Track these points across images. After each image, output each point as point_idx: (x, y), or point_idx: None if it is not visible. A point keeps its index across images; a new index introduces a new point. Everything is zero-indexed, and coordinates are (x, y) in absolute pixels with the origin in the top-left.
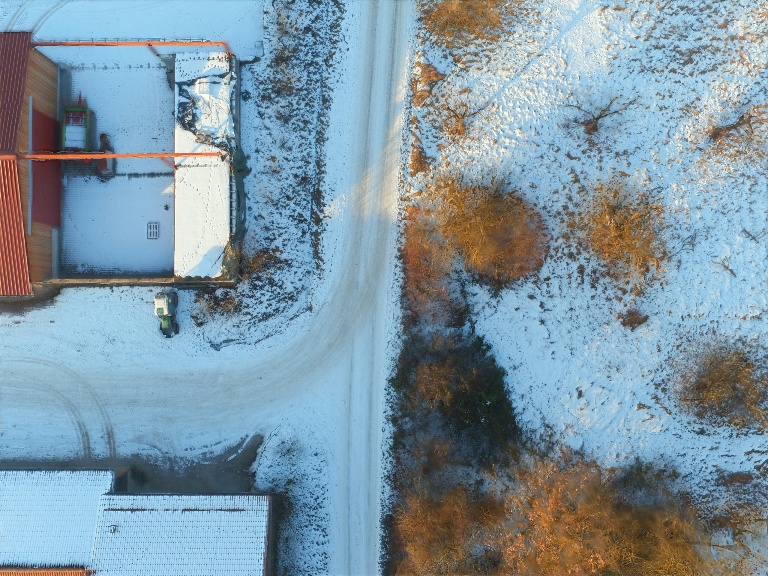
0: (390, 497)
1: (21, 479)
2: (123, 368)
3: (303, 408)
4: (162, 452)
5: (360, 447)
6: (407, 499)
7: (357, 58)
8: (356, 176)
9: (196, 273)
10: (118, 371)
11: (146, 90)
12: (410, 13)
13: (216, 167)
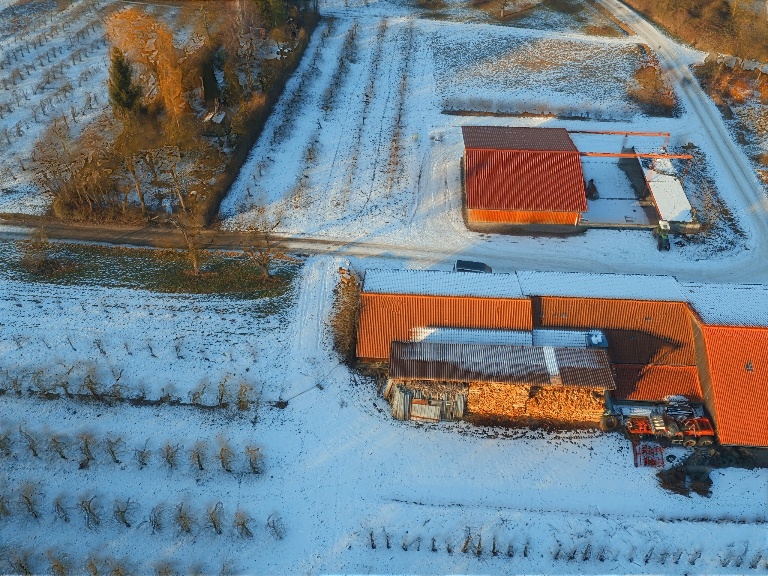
0: None
1: (613, 276)
2: (637, 264)
3: None
4: None
5: None
6: None
7: (721, 168)
8: (745, 205)
9: (676, 220)
10: (634, 265)
11: (607, 170)
12: (742, 157)
13: (672, 182)
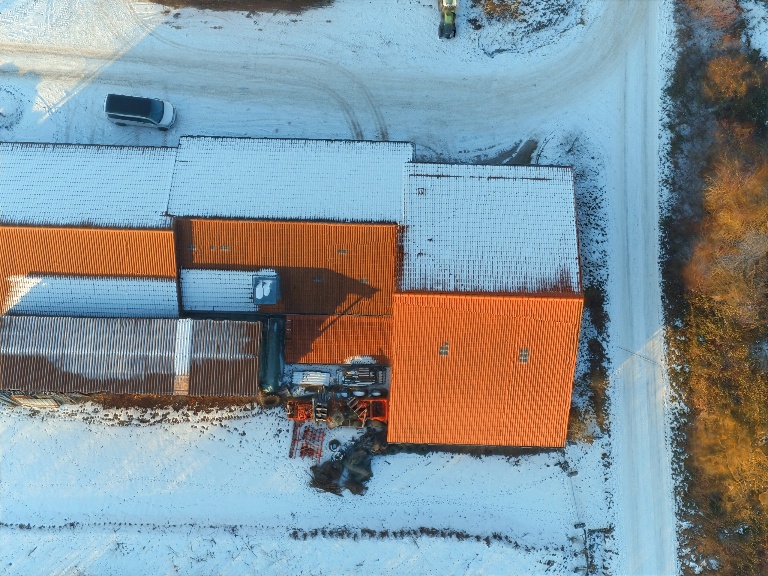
0: (669, 199)
1: (322, 147)
2: (398, 70)
3: (578, 115)
4: (437, 153)
5: (636, 153)
6: (716, 170)
7: None
8: None
9: None
10: (393, 73)
11: None
12: None
13: None
